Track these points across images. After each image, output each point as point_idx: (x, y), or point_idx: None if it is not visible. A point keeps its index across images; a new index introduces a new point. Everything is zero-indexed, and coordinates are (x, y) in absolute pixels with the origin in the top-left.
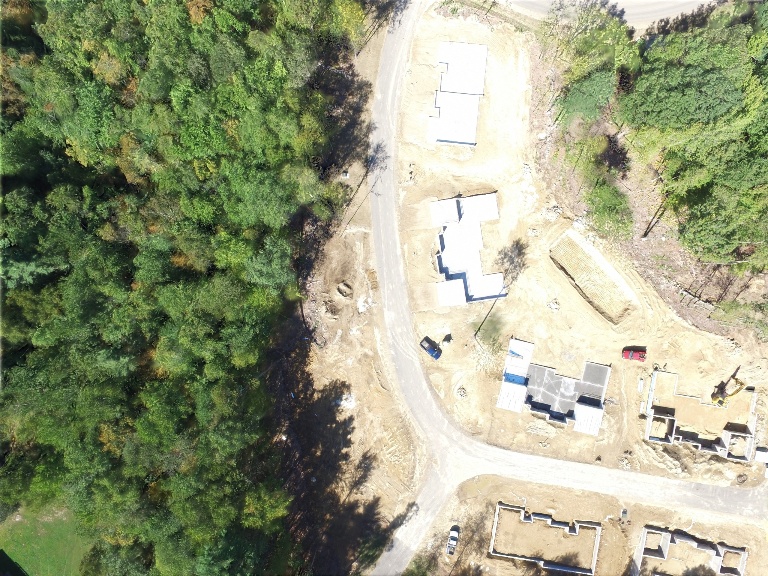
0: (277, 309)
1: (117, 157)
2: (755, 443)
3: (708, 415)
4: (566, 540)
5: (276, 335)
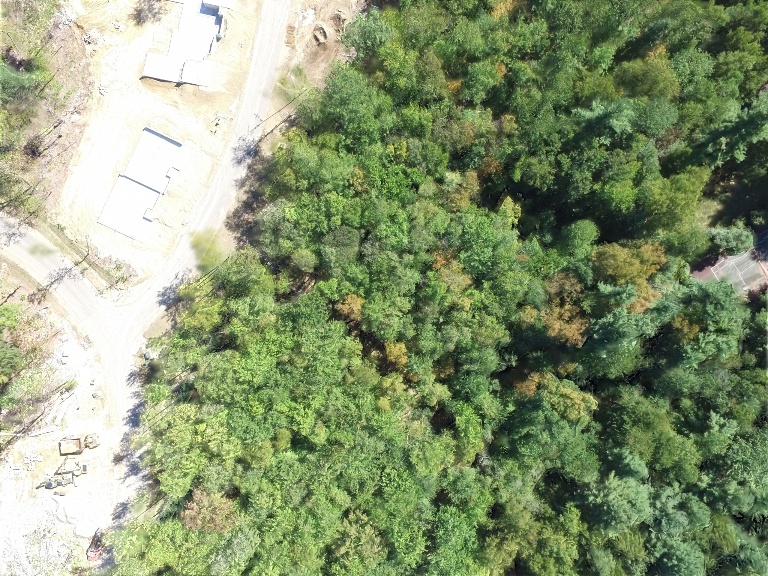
0: None
1: None
2: None
3: None
4: None
5: None
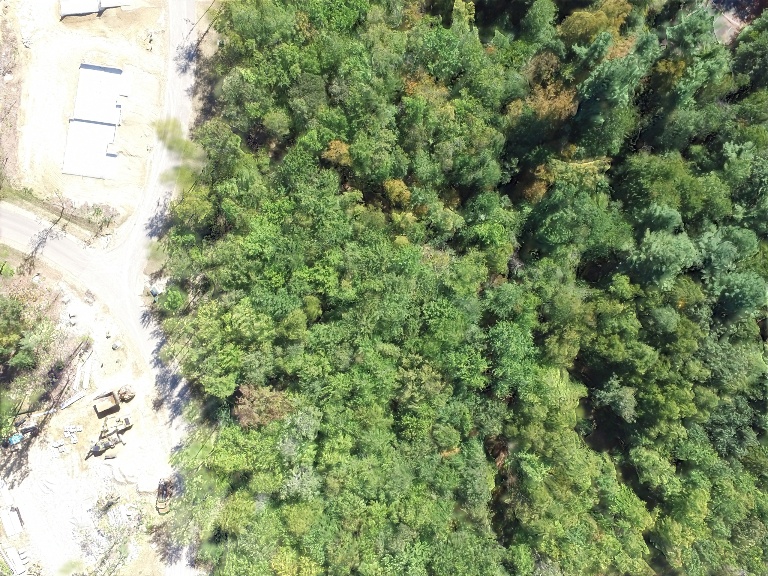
0: None
1: None
2: None
3: None
4: None
5: None
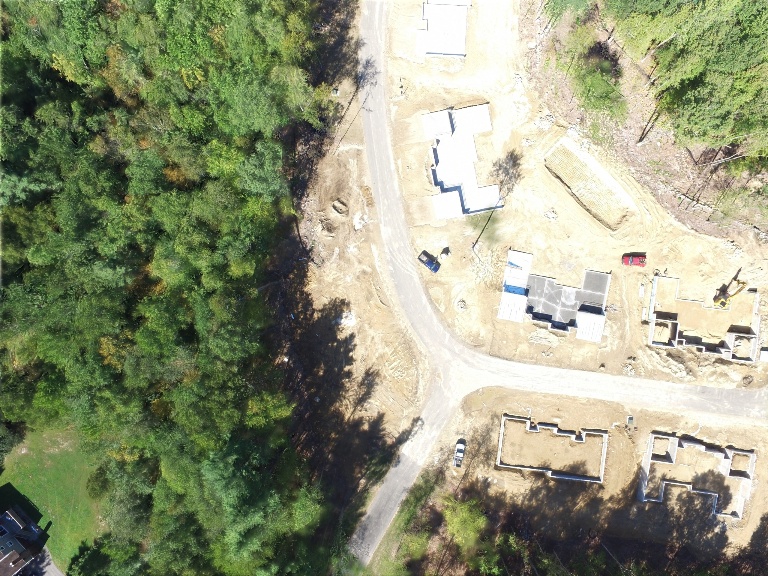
0: (273, 225)
1: (104, 70)
2: (759, 344)
3: (711, 319)
4: (573, 449)
5: (273, 257)
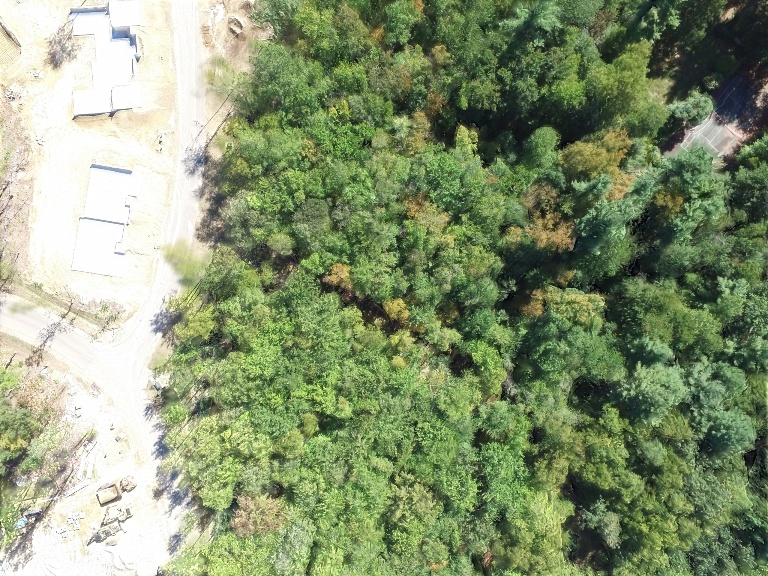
0: None
1: None
2: None
3: None
4: None
5: None
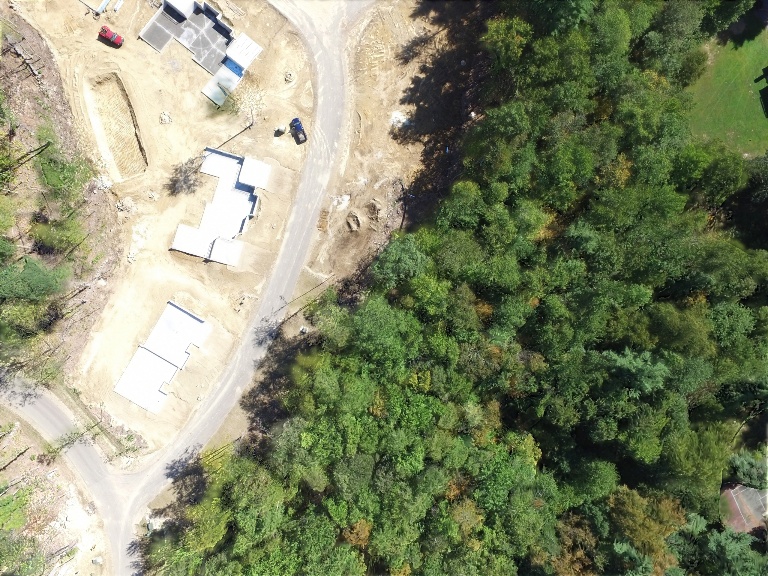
0: None
1: None
2: None
3: None
4: None
5: None
